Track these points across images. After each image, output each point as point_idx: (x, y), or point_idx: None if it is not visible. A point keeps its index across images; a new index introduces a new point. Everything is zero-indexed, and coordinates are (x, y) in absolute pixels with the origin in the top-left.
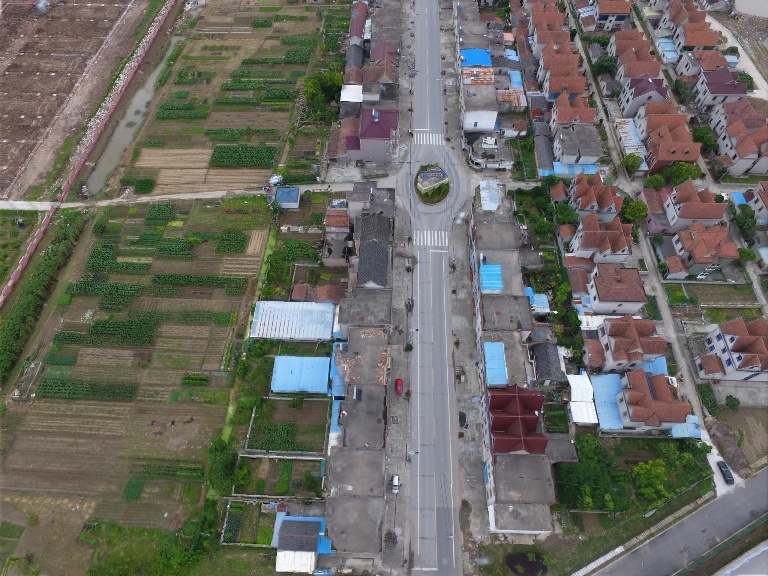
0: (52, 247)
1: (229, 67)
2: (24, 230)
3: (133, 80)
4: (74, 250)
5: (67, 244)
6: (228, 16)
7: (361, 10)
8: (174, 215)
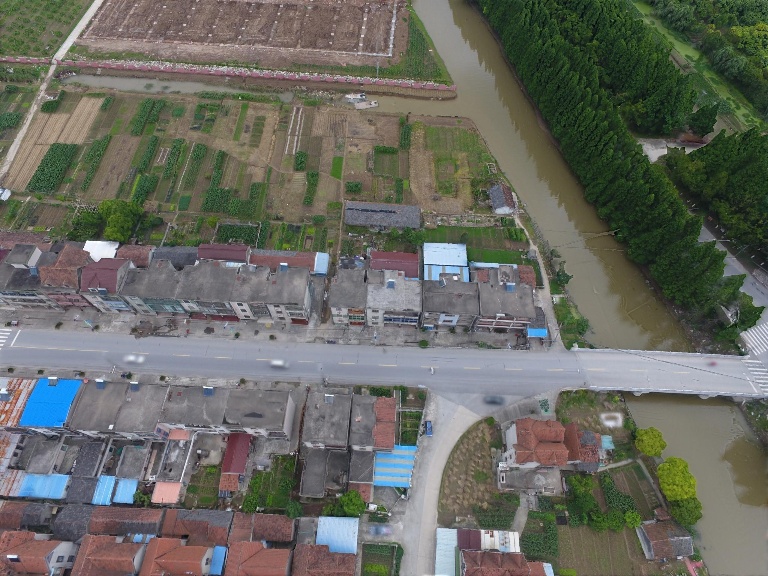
0: (1, 68)
1: (217, 142)
2: (39, 53)
3: (215, 76)
4: (1, 81)
5: (2, 75)
6: (326, 130)
7: (291, 261)
8: (0, 129)
